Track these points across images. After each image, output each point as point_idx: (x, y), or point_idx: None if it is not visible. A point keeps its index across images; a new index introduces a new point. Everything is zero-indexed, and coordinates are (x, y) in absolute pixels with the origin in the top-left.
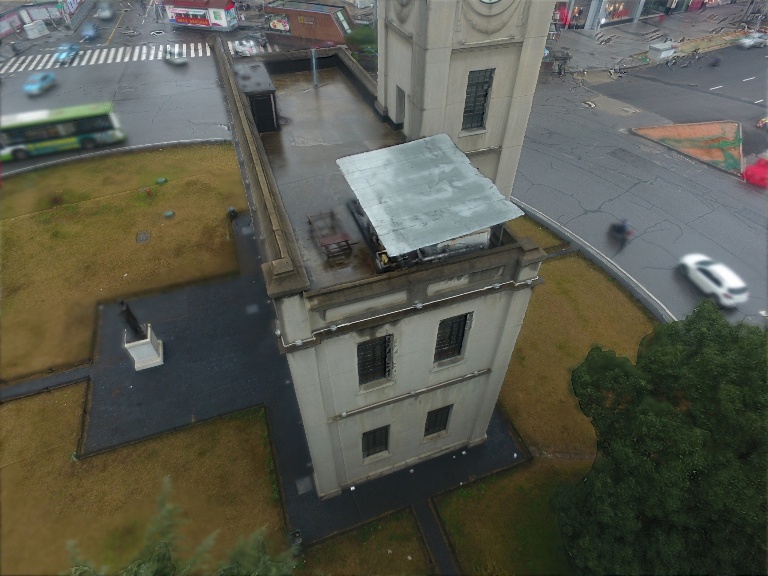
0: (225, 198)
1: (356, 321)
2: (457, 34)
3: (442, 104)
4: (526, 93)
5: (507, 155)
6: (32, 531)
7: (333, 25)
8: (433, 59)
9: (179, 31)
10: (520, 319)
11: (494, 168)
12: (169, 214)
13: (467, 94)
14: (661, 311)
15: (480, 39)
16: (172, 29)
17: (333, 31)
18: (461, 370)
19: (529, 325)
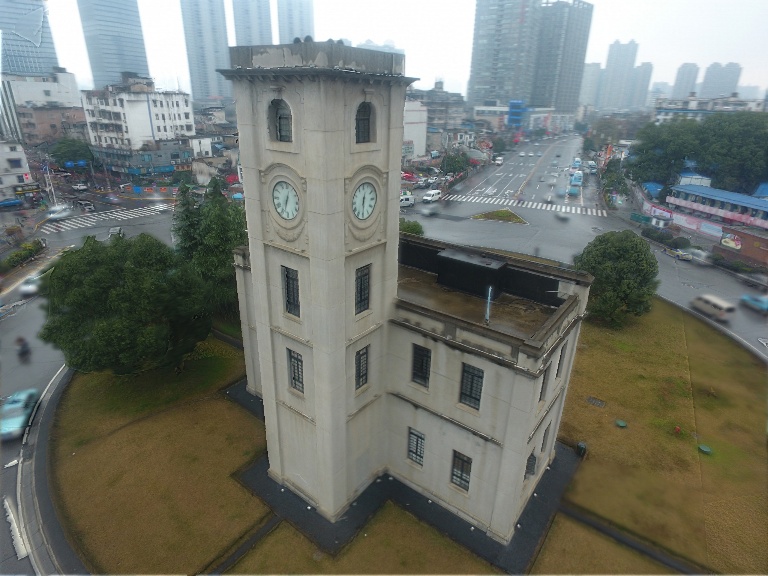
0: (621, 464)
1: None
2: None
3: None
4: None
5: None
6: None
7: None
8: None
9: None
10: None
11: None
12: (618, 422)
13: None
14: (52, 570)
15: None
16: None
17: None
18: None
19: (224, 469)
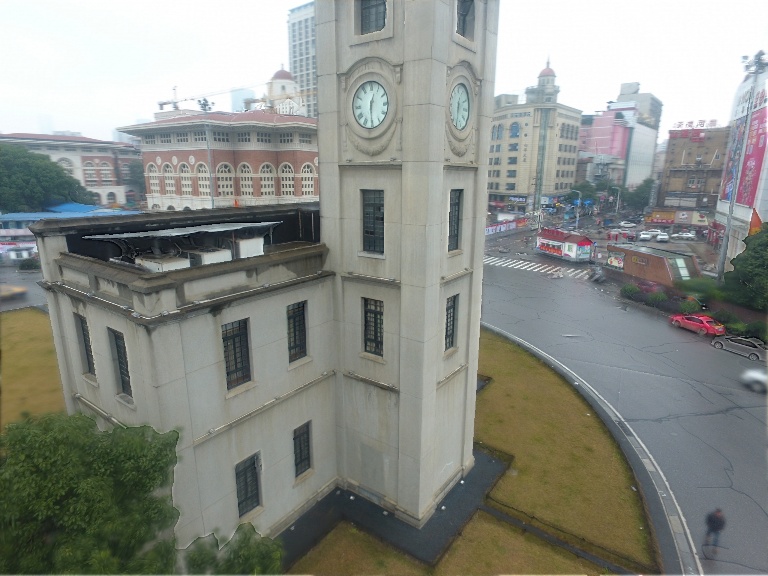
0: None
1: (71, 287)
2: (345, 153)
3: (336, 215)
4: (416, 222)
5: (409, 295)
6: (54, 407)
7: (664, 268)
8: (325, 172)
9: (538, 255)
10: (152, 376)
11: (399, 308)
12: None
13: (367, 214)
14: None
15: (365, 160)
16: (535, 254)
17: (663, 274)
18: (137, 423)
19: None
